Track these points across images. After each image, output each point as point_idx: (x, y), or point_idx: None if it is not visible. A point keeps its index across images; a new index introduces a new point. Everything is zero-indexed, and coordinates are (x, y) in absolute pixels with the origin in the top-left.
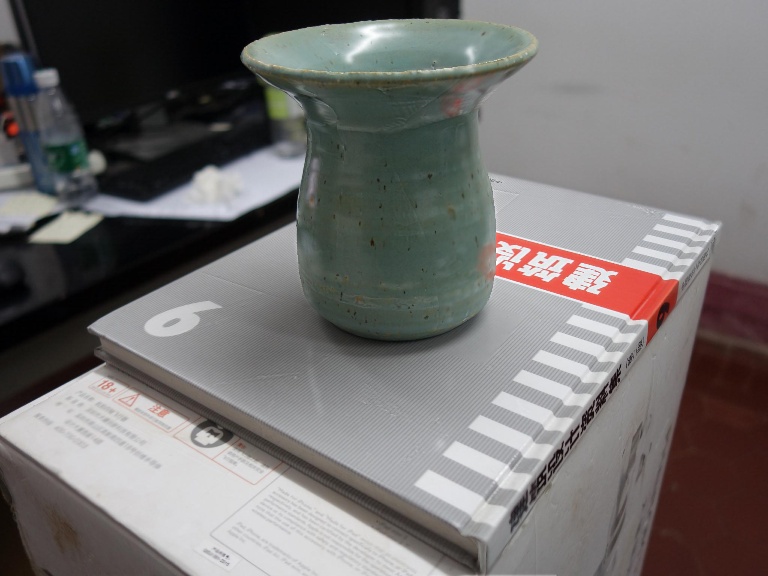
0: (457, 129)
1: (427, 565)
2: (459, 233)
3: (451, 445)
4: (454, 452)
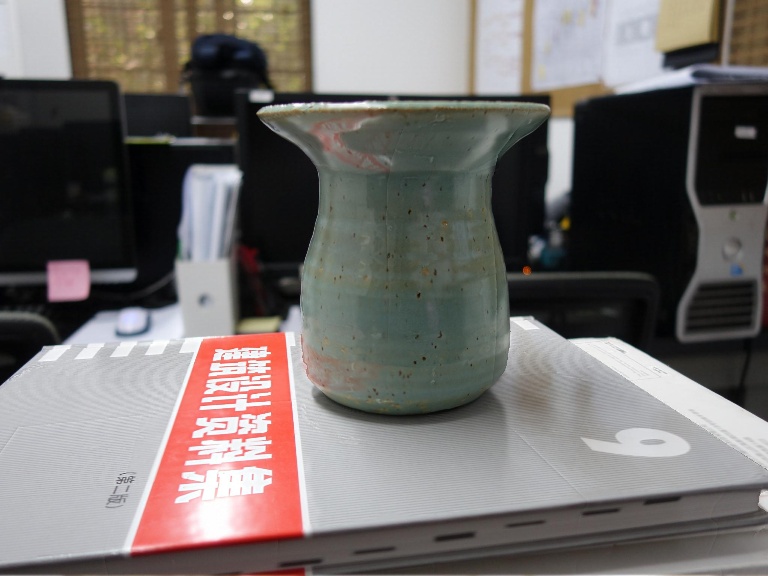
0: None
1: None
2: None
3: None
4: None
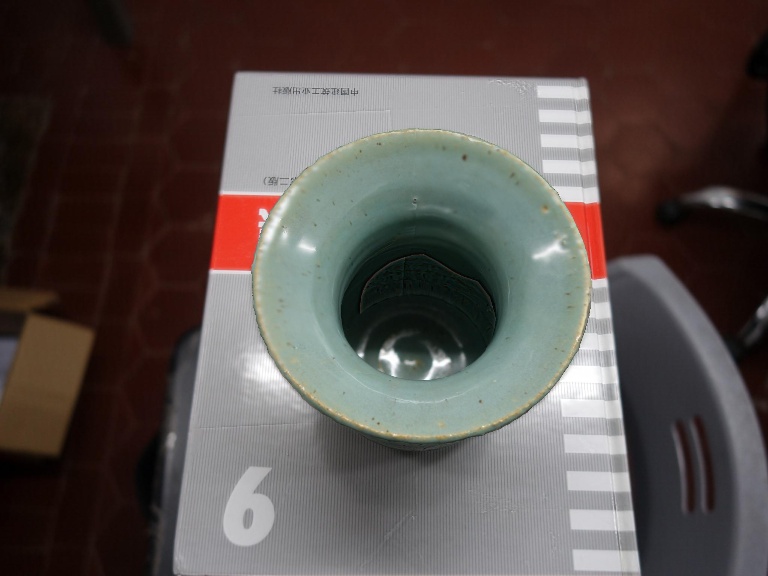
0: None
1: None
2: None
3: (570, 516)
4: (576, 522)
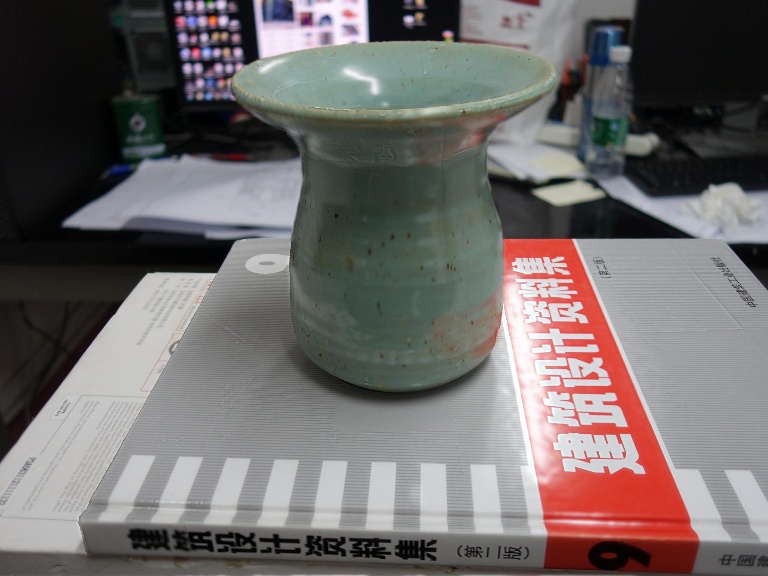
0: (371, 178)
1: None
2: (354, 288)
3: (195, 457)
4: (186, 462)
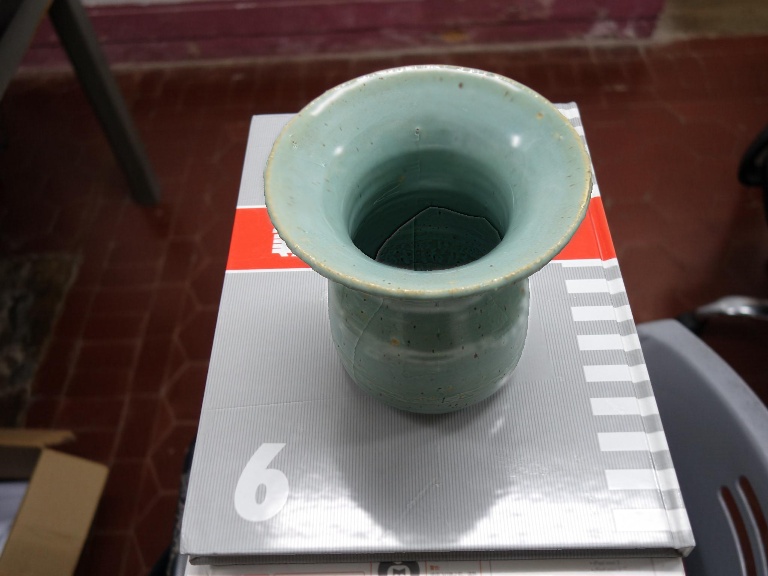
0: None
1: (649, 574)
2: (527, 301)
3: (606, 476)
4: (614, 482)
